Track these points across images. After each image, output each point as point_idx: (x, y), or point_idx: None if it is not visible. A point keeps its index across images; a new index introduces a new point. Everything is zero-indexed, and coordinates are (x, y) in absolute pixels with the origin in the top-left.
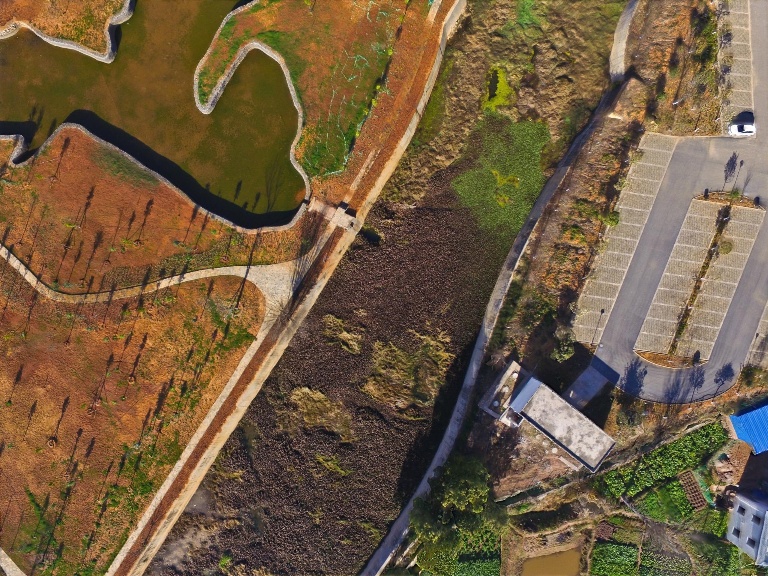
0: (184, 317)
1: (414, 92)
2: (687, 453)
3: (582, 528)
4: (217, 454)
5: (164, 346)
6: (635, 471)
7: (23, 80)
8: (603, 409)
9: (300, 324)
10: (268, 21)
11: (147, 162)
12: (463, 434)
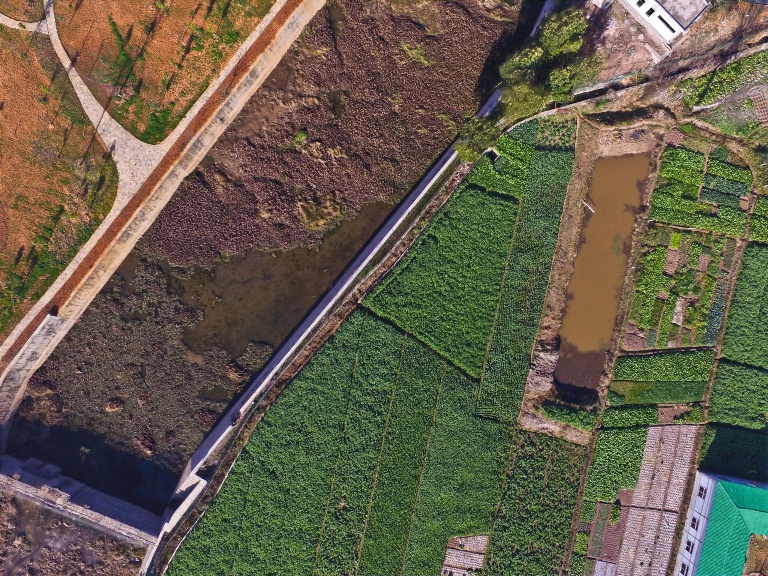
0: None
1: None
2: (760, 69)
3: (655, 129)
4: (302, 29)
5: None
6: (709, 84)
7: None
8: None
9: None
10: None
11: None
12: None
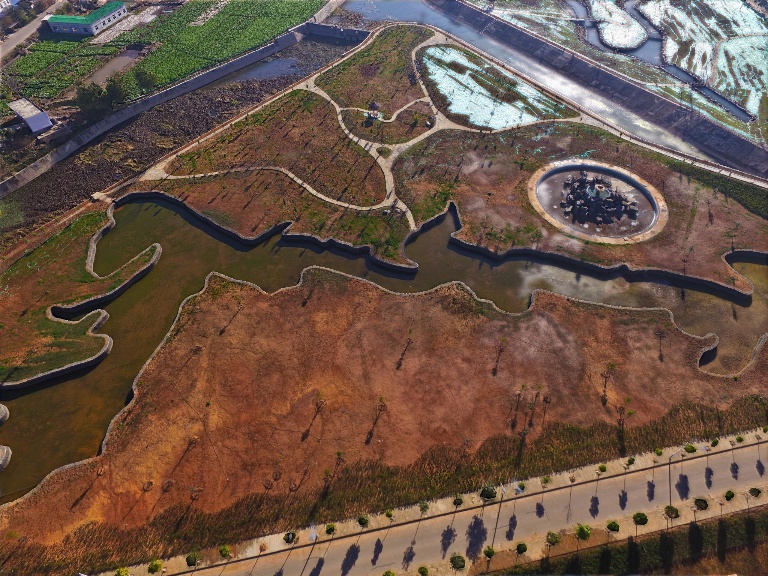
0: None
1: (8, 252)
2: None
3: None
4: None
5: None
6: None
7: (280, 268)
8: (7, 123)
9: None
10: (83, 288)
11: (213, 231)
12: (88, 124)
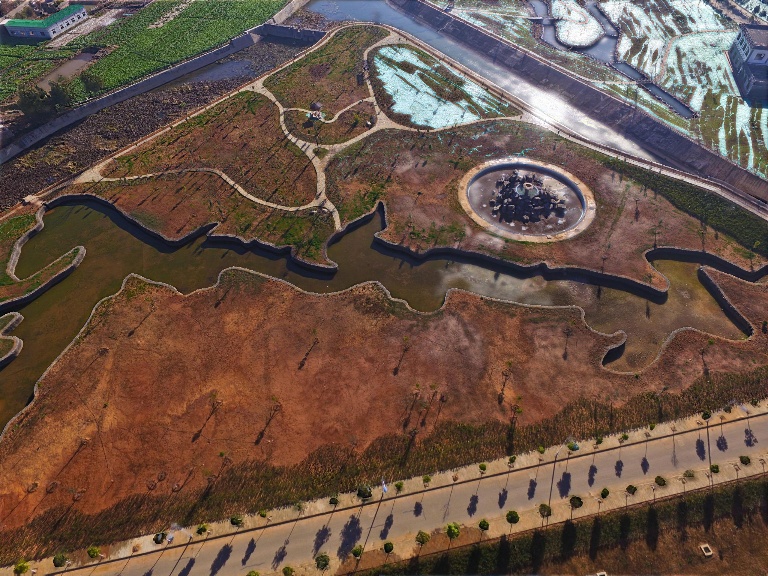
0: None
1: None
2: None
3: None
4: None
5: None
6: None
7: (201, 269)
8: None
9: None
10: (0, 291)
11: None
12: (31, 128)
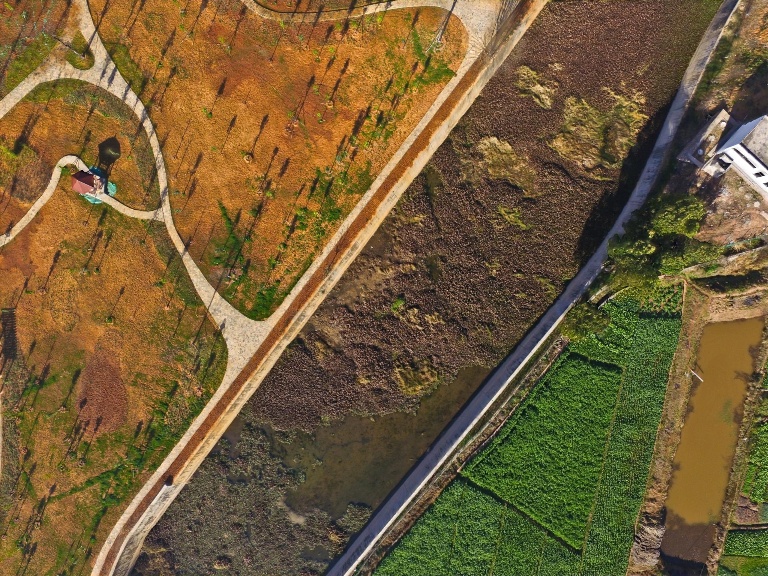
0: (387, 46)
1: None
2: None
3: None
4: (399, 197)
5: (364, 74)
6: None
7: None
8: None
9: (493, 73)
10: None
11: None
12: (658, 187)
